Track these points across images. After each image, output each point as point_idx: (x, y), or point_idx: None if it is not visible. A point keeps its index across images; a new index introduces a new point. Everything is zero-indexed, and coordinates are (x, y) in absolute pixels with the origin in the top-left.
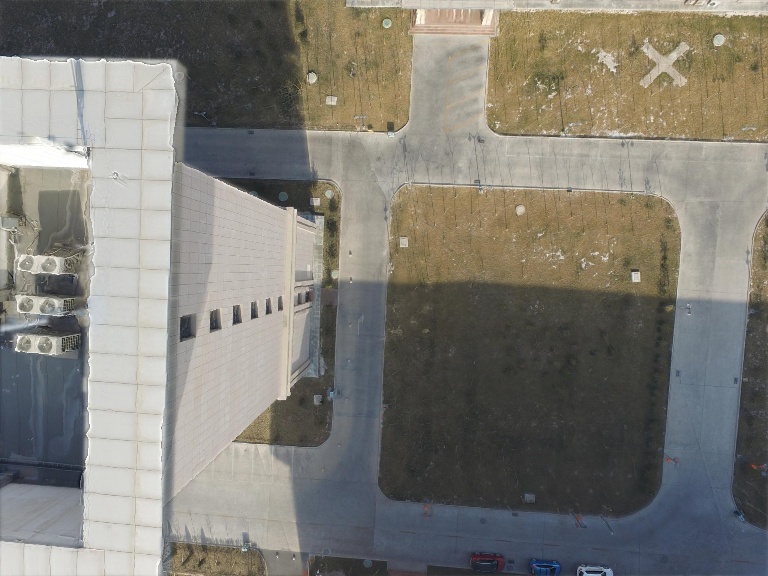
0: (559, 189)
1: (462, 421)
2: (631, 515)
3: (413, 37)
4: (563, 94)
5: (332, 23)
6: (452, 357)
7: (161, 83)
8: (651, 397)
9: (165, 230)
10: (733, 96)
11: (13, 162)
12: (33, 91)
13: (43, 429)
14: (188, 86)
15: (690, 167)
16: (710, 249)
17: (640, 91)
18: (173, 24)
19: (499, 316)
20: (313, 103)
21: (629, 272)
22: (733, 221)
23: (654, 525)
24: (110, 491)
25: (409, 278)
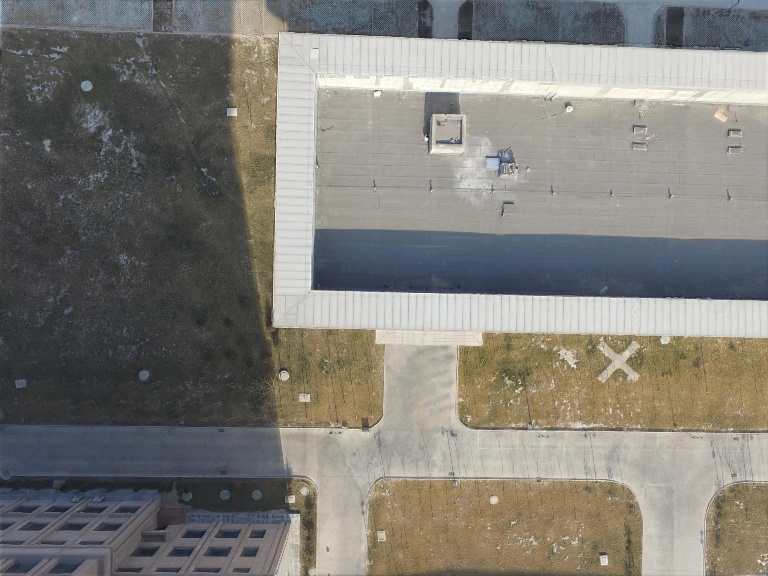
0: (529, 480)
1: None
2: None
3: None
4: (529, 389)
5: None
6: None
7: None
8: None
9: None
10: (680, 389)
11: None
12: None
13: None
14: (153, 385)
15: (647, 455)
16: (668, 531)
17: (599, 385)
18: (136, 321)
19: None
20: (286, 400)
21: (597, 555)
22: (687, 504)
23: None
24: None
25: (388, 571)
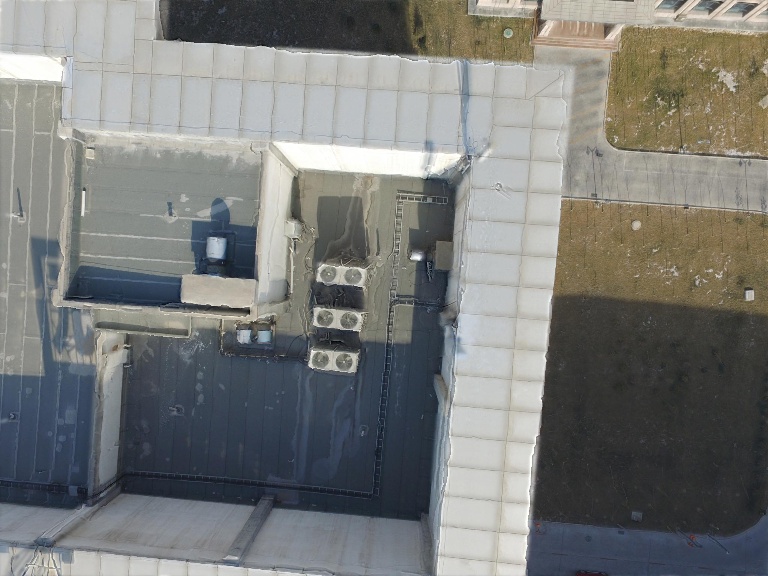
0: (676, 205)
1: (570, 437)
2: (738, 534)
3: (534, 48)
4: (683, 111)
5: (452, 30)
6: (562, 371)
7: (556, 90)
8: (761, 416)
9: (551, 246)
10: None
11: (306, 165)
12: (412, 93)
13: (307, 450)
14: None
15: None
16: None
17: (759, 111)
18: (287, 24)
19: (611, 331)
20: None
21: (743, 290)
22: None
23: (760, 544)
24: (471, 525)
25: None
